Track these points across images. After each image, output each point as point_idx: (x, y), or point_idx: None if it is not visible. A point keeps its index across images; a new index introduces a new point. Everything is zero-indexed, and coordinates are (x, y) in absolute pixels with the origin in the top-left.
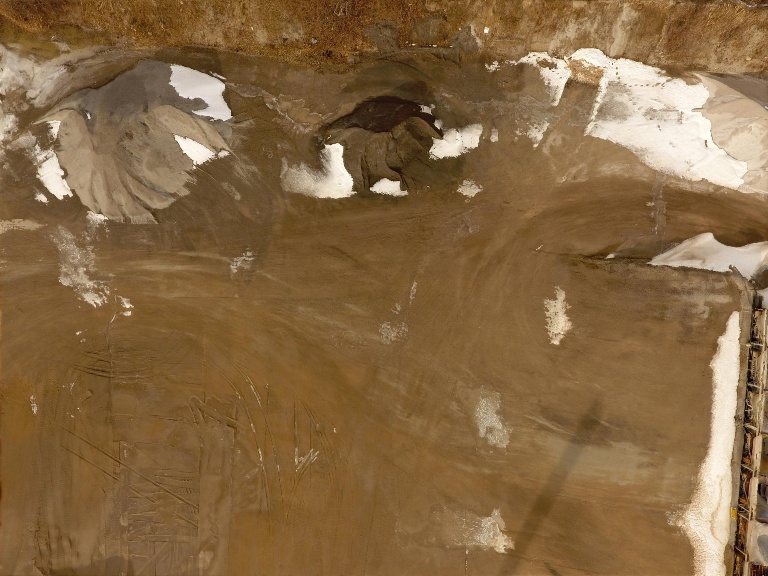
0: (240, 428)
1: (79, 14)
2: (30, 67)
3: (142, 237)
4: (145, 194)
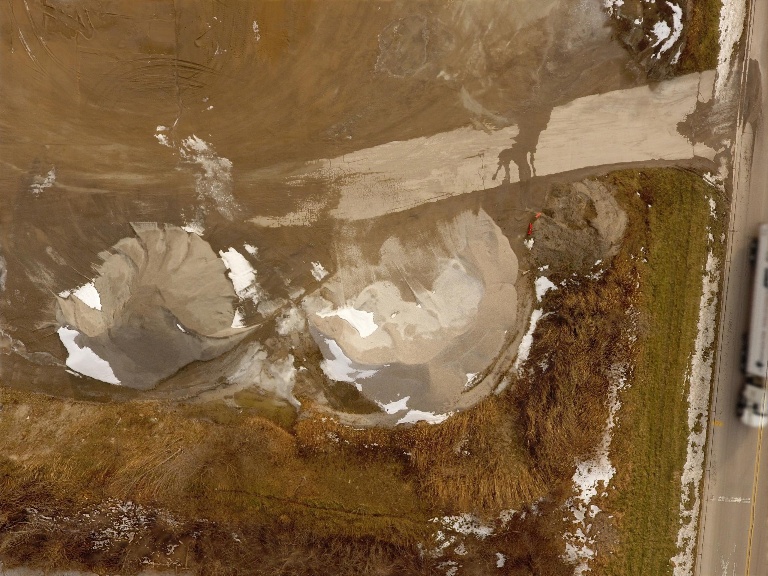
0: (40, 5)
1: (211, 434)
2: (264, 382)
3: (146, 208)
4: (135, 251)
